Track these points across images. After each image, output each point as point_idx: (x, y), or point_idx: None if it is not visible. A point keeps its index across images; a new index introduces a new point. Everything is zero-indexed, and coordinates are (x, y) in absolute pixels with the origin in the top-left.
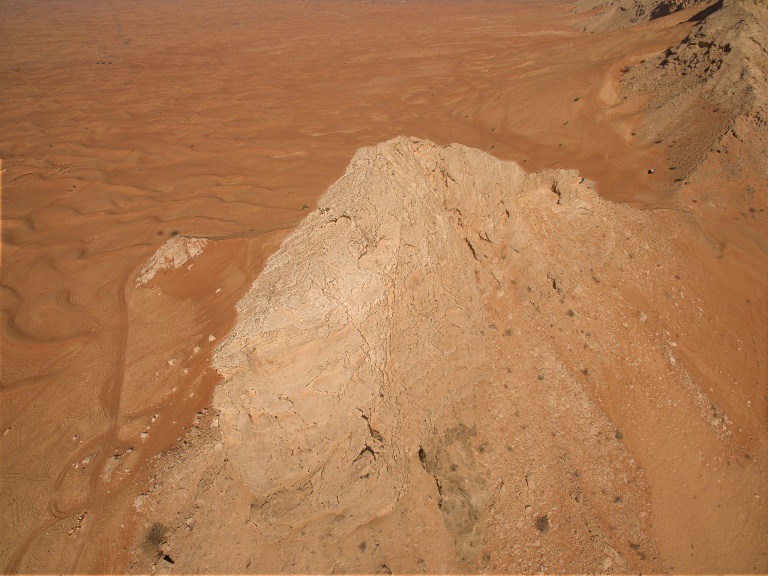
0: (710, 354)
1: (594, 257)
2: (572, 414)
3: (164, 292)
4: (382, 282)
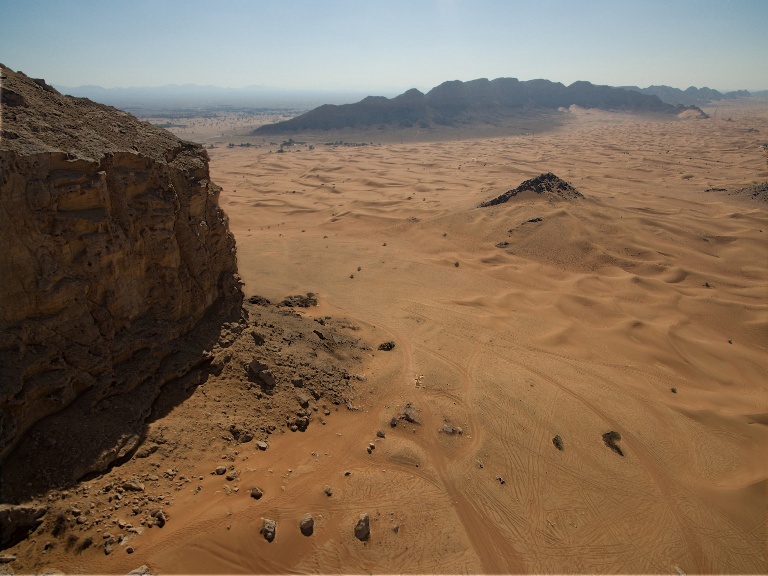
0: None
1: None
2: None
3: None
4: None
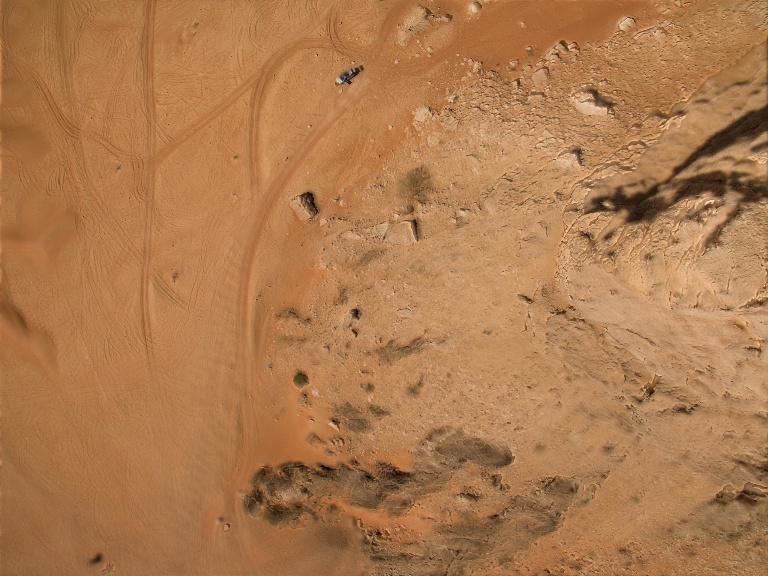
0: None
1: None
2: None
3: None
4: None
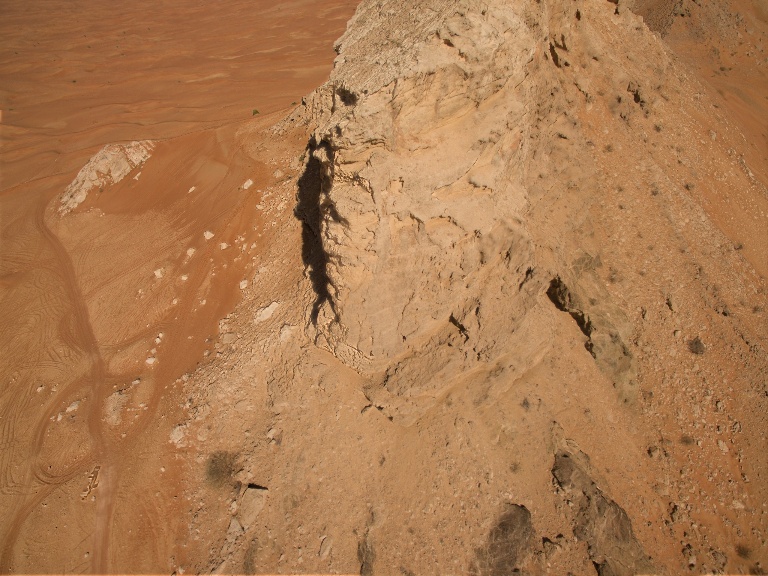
0: (767, 173)
1: (656, 75)
2: (693, 228)
3: (107, 212)
4: (529, 32)
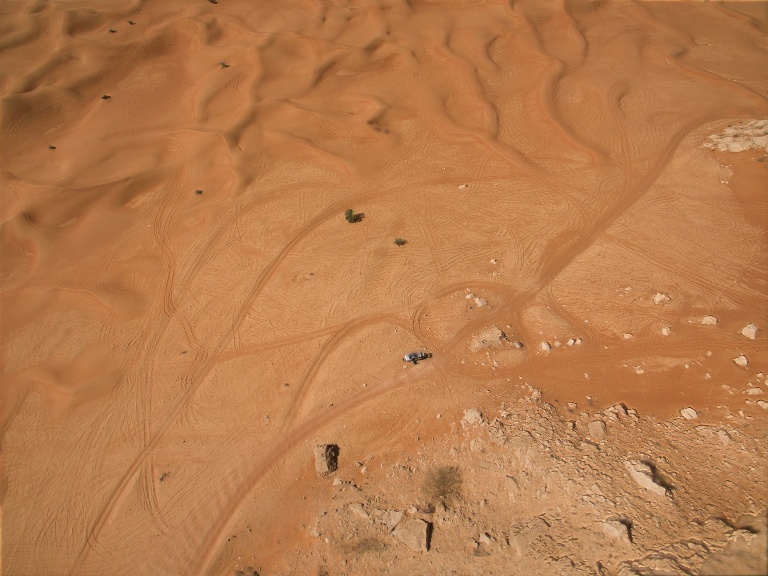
0: None
1: None
2: None
3: (732, 184)
4: None
